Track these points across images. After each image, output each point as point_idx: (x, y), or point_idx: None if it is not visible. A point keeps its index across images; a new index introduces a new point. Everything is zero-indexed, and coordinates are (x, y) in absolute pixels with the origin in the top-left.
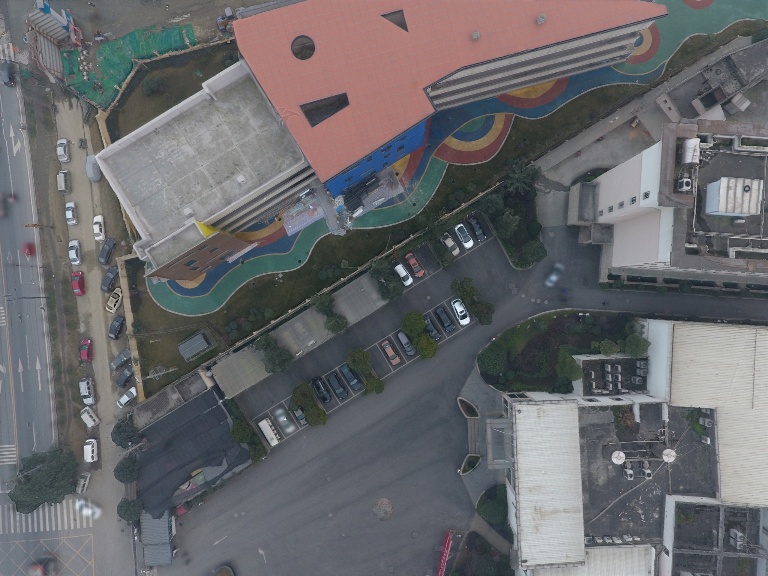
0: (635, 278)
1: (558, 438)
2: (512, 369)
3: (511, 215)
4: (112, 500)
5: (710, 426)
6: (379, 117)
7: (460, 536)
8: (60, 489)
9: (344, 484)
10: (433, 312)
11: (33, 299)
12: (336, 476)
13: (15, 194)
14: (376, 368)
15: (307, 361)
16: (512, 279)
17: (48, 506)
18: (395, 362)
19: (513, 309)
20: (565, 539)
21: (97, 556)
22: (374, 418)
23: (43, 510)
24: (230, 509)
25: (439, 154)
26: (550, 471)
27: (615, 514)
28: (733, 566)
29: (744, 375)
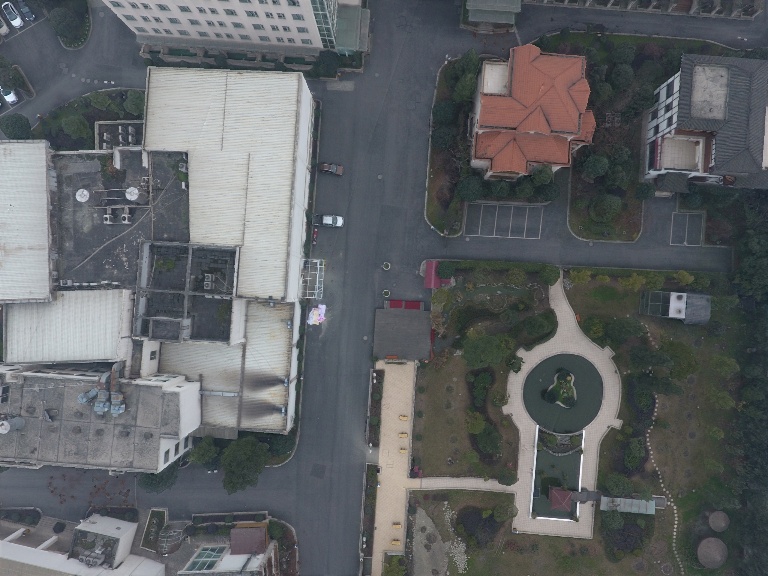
0: (172, 52)
1: (24, 177)
2: (55, 145)
3: None
4: None
5: (182, 169)
6: None
7: (0, 309)
8: None
9: None
10: None
11: None
12: None
13: None
14: None
15: None
16: (63, 59)
17: None
18: None
19: (63, 89)
20: (29, 276)
21: None
22: None
23: None
24: None
25: None
26: (15, 209)
27: (99, 261)
28: (212, 312)
29: (215, 118)
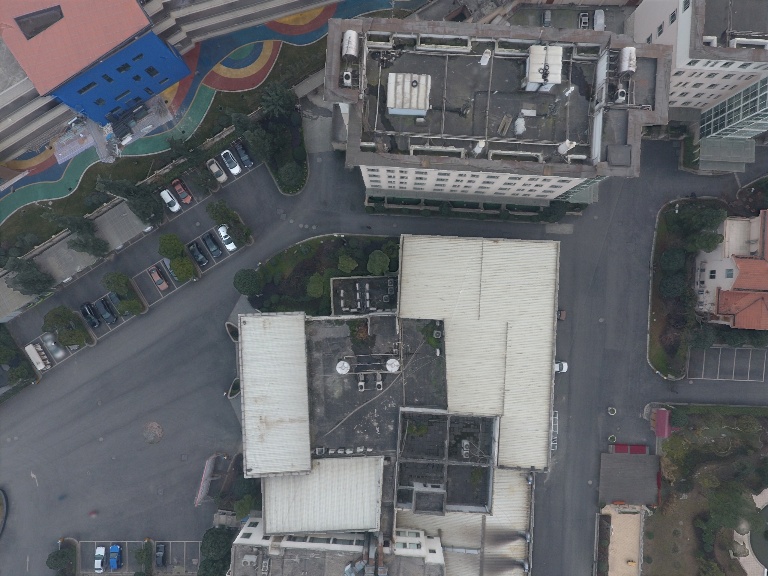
0: (396, 201)
1: (284, 349)
2: (277, 293)
3: (258, 135)
4: None
5: (438, 337)
6: (94, 29)
7: (226, 458)
8: None
9: (115, 408)
10: (202, 238)
11: None
12: (107, 401)
13: None
14: (146, 294)
15: (78, 288)
16: (280, 205)
17: None
18: (163, 287)
19: (281, 235)
20: (291, 448)
21: None
22: (144, 343)
23: None
24: (3, 434)
25: (208, 81)
26: (276, 381)
27: (351, 427)
28: (466, 477)
29: (471, 286)
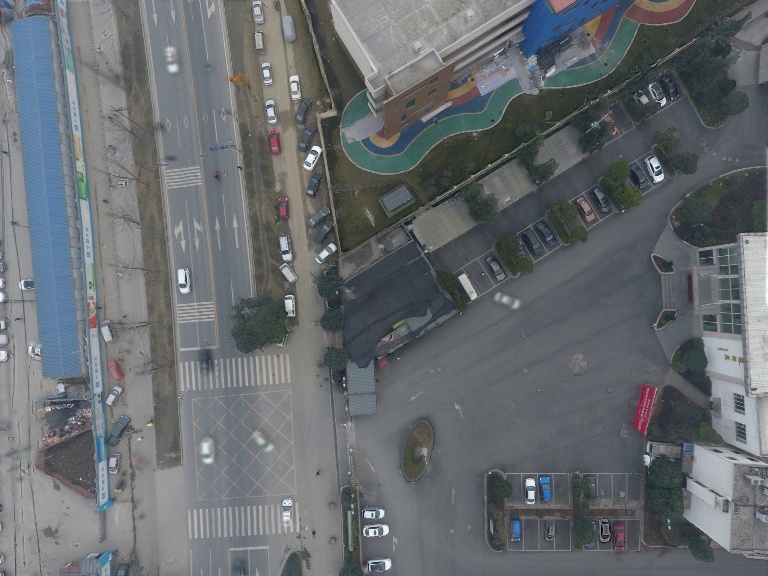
0: None
1: None
2: (707, 224)
3: None
4: (310, 356)
5: None
6: None
7: (657, 389)
8: (281, 328)
9: (539, 340)
10: None
11: (230, 158)
12: (531, 332)
13: (210, 55)
14: (569, 226)
15: (501, 219)
16: (703, 138)
17: (247, 361)
18: (590, 218)
19: (705, 167)
20: None
21: (296, 411)
22: (568, 275)
23: (242, 366)
24: (426, 365)
25: (630, 15)
26: None
27: None
28: None
29: None
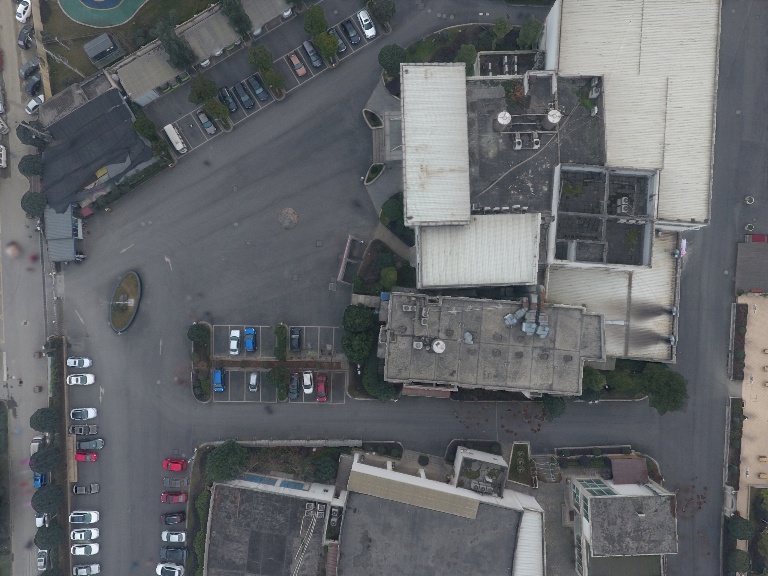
0: None
1: (445, 99)
2: None
3: None
4: (20, 207)
5: (597, 93)
6: None
7: (363, 242)
8: None
9: (250, 194)
10: (340, 26)
11: None
12: (242, 186)
13: None
14: None
15: (215, 74)
16: None
17: None
18: (301, 72)
19: (419, 24)
20: (451, 198)
21: (5, 261)
22: (280, 130)
23: None
24: (137, 218)
25: None
26: (437, 131)
27: (505, 187)
28: (620, 237)
29: (631, 42)
